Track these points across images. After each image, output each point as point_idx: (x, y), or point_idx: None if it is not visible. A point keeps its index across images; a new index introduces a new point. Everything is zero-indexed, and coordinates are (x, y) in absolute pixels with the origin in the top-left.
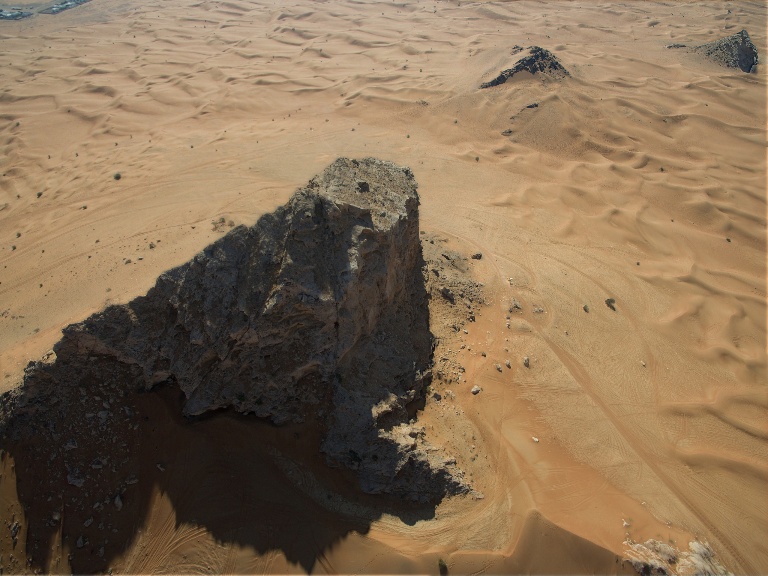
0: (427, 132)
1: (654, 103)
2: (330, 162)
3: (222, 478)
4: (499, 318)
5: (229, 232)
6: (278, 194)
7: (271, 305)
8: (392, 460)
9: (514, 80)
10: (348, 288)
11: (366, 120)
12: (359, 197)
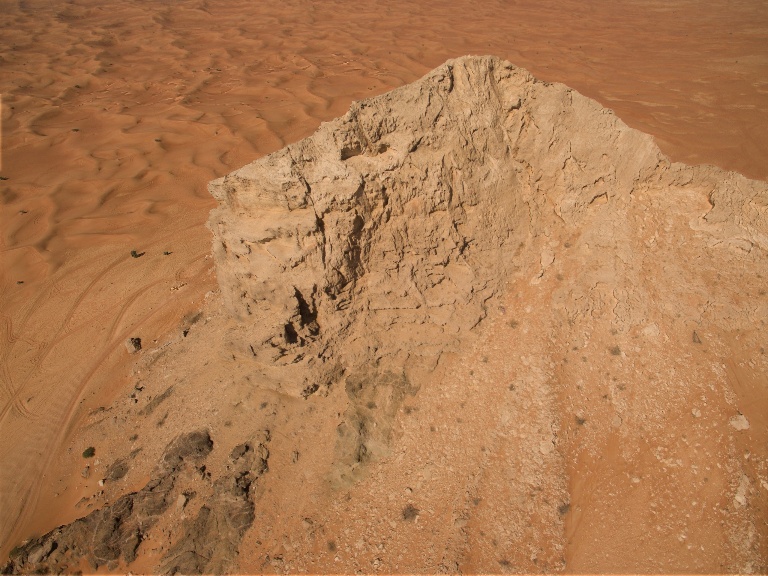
0: None
1: None
2: None
3: None
4: None
5: None
6: None
7: None
8: None
9: None
10: None
11: None
12: None
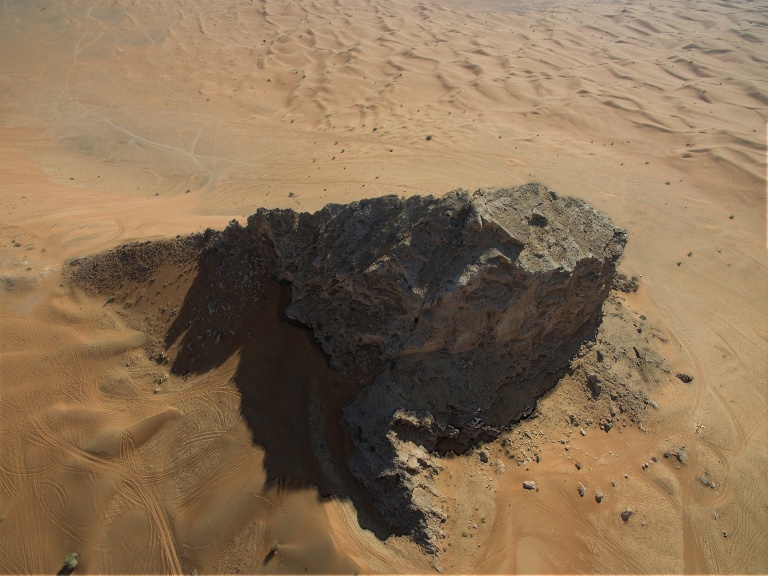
0: (763, 223)
1: None
2: (610, 202)
3: (273, 372)
4: (642, 451)
5: (384, 196)
6: None
7: (372, 269)
8: (384, 463)
9: None
10: (445, 296)
11: (694, 180)
12: (521, 226)
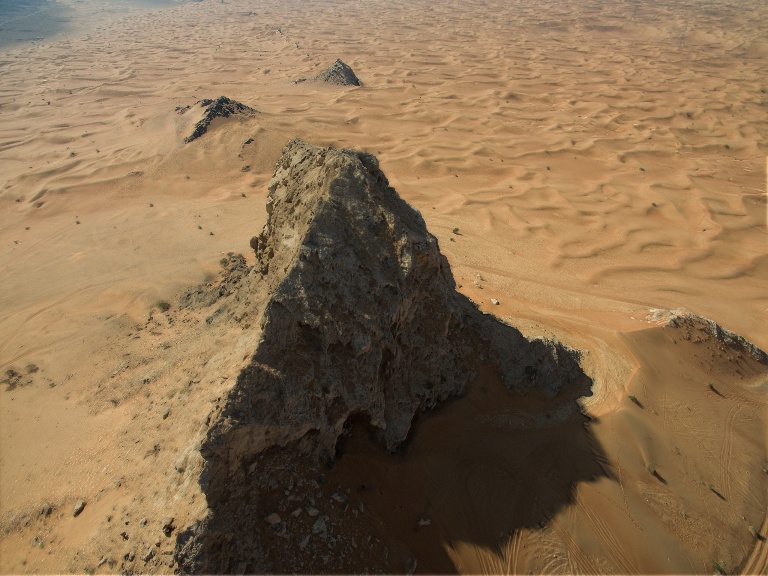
0: (166, 196)
1: (329, 116)
2: (93, 256)
3: (478, 476)
4: None
5: (315, 212)
6: (62, 311)
7: (409, 262)
8: (548, 355)
9: (214, 127)
10: None
11: (82, 210)
12: None
